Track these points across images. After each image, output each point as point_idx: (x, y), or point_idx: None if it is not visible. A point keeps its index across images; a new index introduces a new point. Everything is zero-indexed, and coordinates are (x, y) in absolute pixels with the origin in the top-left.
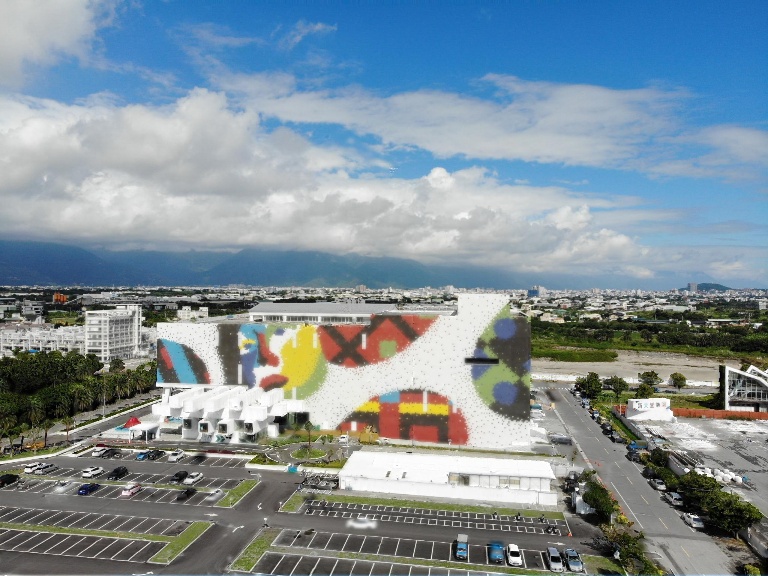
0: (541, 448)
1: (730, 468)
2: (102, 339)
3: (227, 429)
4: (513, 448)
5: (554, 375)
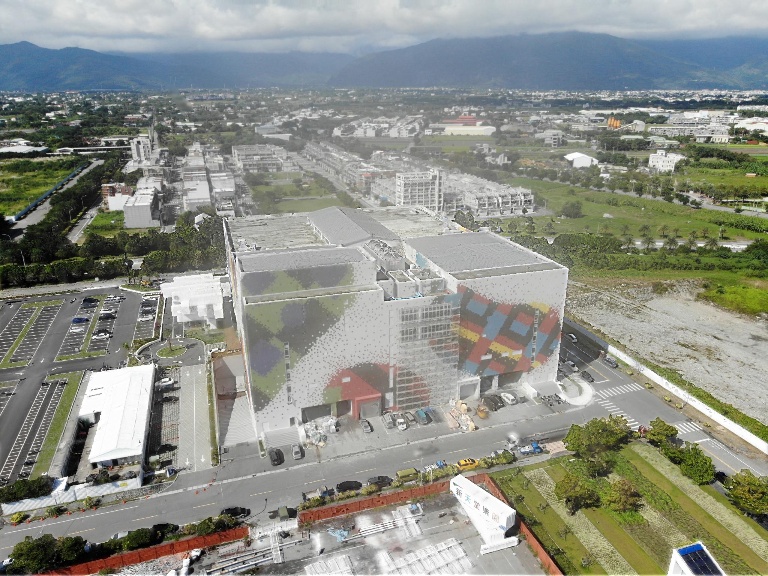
0: (249, 447)
1: None
2: (401, 198)
3: (172, 312)
4: (250, 432)
5: (692, 397)
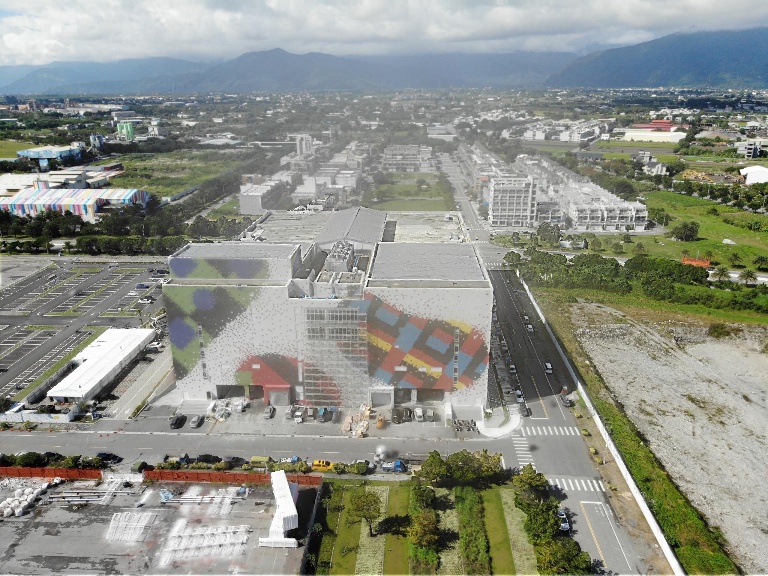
0: (167, 410)
1: (37, 526)
2: None
3: None
4: None
5: None
